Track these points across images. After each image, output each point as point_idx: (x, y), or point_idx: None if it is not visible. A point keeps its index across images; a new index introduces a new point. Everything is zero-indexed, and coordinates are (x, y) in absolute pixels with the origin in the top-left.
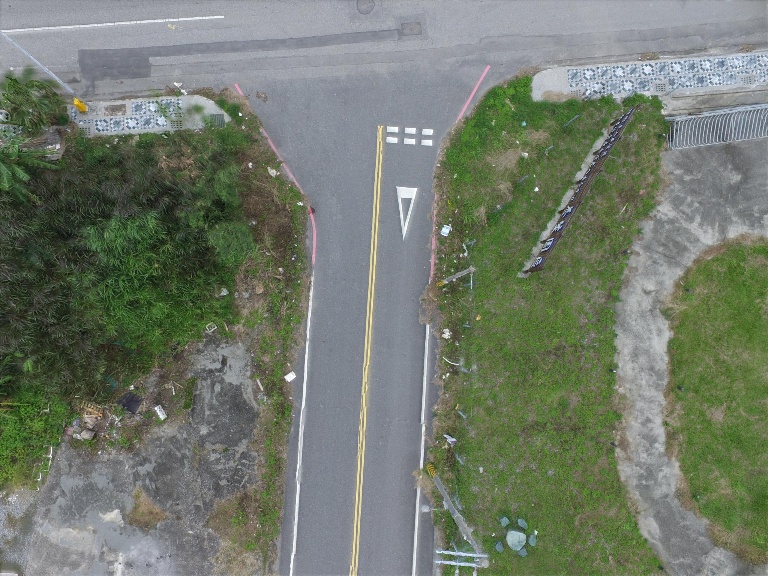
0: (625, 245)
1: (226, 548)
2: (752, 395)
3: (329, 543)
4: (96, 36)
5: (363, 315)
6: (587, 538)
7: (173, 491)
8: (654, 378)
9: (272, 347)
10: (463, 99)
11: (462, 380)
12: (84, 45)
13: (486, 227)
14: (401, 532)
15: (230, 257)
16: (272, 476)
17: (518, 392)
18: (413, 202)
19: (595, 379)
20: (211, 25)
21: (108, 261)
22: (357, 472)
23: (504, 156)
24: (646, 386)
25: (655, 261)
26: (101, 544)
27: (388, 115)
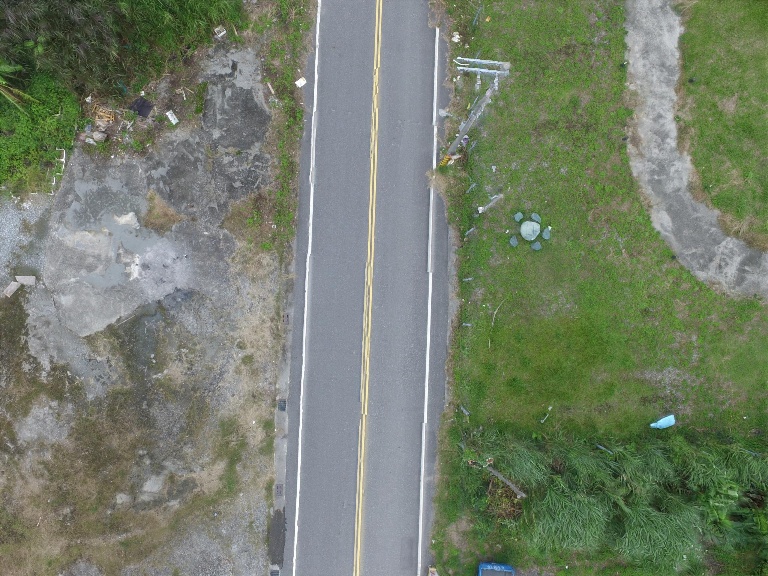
0: None
1: (242, 248)
2: (763, 84)
3: (344, 242)
4: None
5: (372, 20)
6: (600, 232)
7: (187, 194)
8: (665, 74)
9: (282, 50)
10: None
11: (473, 81)
12: None
13: None
14: (415, 230)
15: None
16: (286, 178)
17: (529, 91)
18: None
19: (606, 76)
20: None
21: None
22: (370, 171)
23: None
24: (657, 82)
25: None
26: (117, 246)
27: None
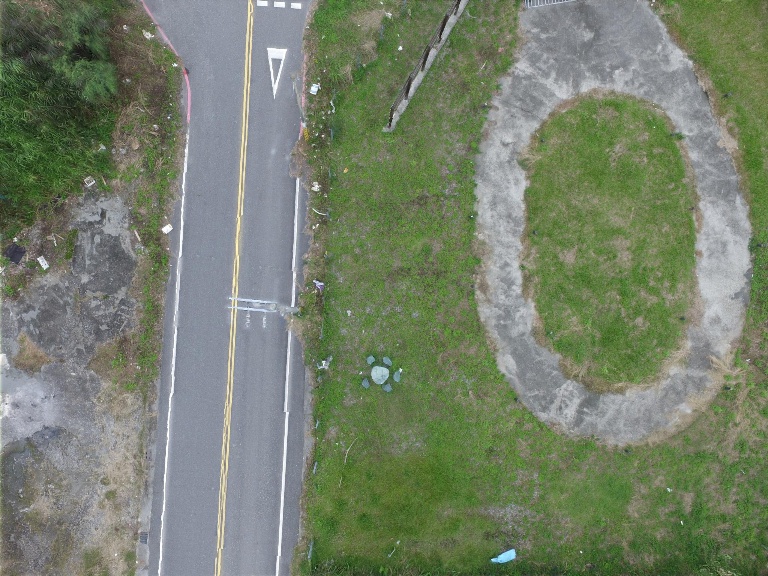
0: (484, 100)
1: (107, 388)
2: (602, 237)
3: (205, 383)
4: None
5: (236, 170)
6: (449, 374)
7: (56, 336)
8: (511, 224)
9: (148, 200)
10: None
11: (330, 229)
12: None
13: (352, 85)
14: (273, 372)
15: (103, 111)
16: (150, 321)
17: (383, 240)
18: (283, 62)
19: (456, 226)
20: None
21: None
22: (231, 316)
23: (369, 16)
24: (504, 232)
25: (513, 115)
26: None
27: None
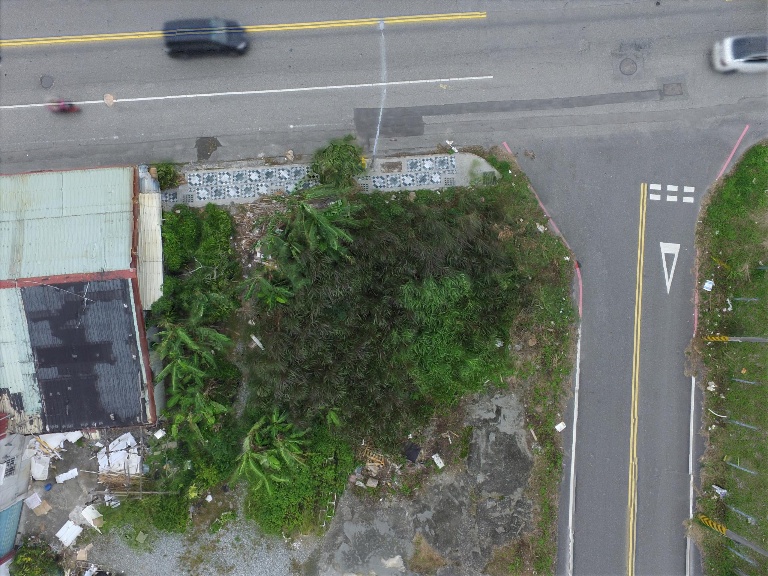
0: None
1: None
2: None
3: None
4: (371, 95)
5: (630, 367)
6: None
7: (452, 538)
8: None
9: (545, 398)
10: (723, 157)
11: (729, 432)
12: (359, 104)
13: (749, 283)
14: None
15: None
16: (547, 524)
17: None
18: (677, 258)
19: None
20: (480, 85)
21: (420, 320)
22: (630, 521)
23: (767, 214)
24: None
25: None
26: None
27: (651, 173)
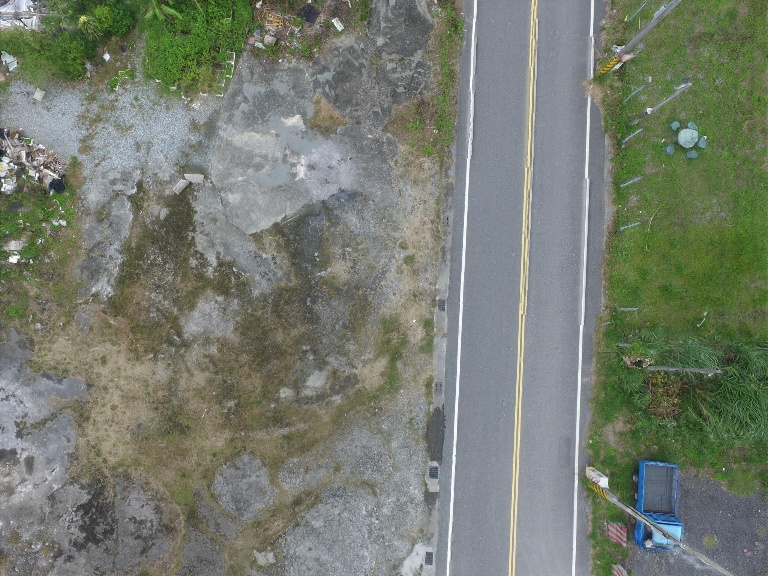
0: None
1: (404, 152)
2: None
3: (504, 148)
4: None
5: None
6: (755, 143)
7: (352, 98)
8: None
9: None
10: None
11: None
12: None
13: None
14: (573, 138)
15: None
16: (447, 85)
17: (685, 5)
18: None
19: None
20: None
21: None
22: (530, 80)
23: None
24: None
25: None
26: (284, 147)
27: None
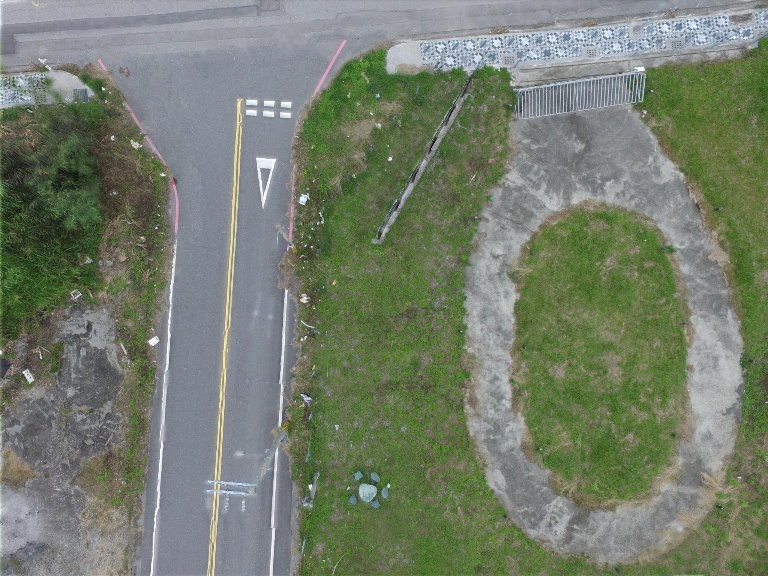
0: (474, 212)
1: (92, 504)
2: (592, 353)
3: (191, 498)
4: None
5: (224, 281)
6: (437, 490)
7: (41, 451)
8: (501, 338)
9: (135, 312)
10: (320, 73)
11: (319, 342)
12: None
13: (341, 196)
14: (260, 487)
15: (90, 226)
16: (136, 435)
17: (372, 353)
18: (272, 172)
19: (445, 340)
20: (74, 2)
21: None
22: (217, 430)
23: (358, 127)
24: (494, 346)
25: (503, 227)
26: None
27: (247, 89)
